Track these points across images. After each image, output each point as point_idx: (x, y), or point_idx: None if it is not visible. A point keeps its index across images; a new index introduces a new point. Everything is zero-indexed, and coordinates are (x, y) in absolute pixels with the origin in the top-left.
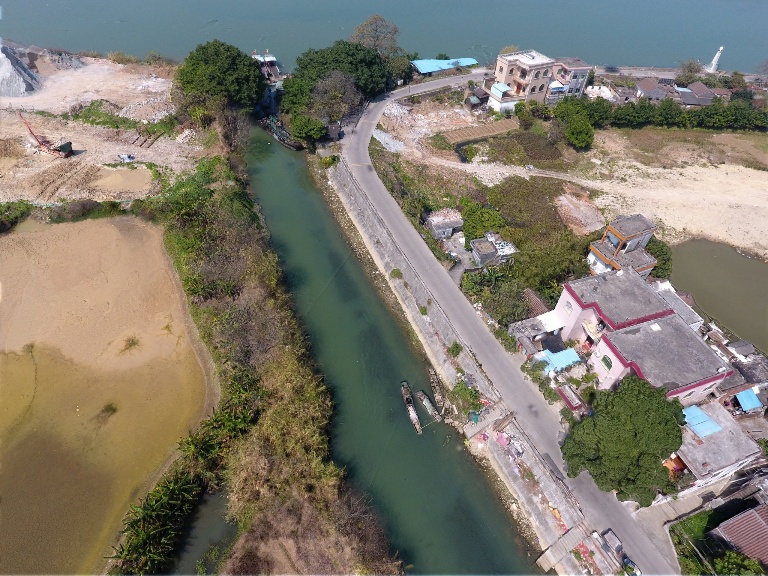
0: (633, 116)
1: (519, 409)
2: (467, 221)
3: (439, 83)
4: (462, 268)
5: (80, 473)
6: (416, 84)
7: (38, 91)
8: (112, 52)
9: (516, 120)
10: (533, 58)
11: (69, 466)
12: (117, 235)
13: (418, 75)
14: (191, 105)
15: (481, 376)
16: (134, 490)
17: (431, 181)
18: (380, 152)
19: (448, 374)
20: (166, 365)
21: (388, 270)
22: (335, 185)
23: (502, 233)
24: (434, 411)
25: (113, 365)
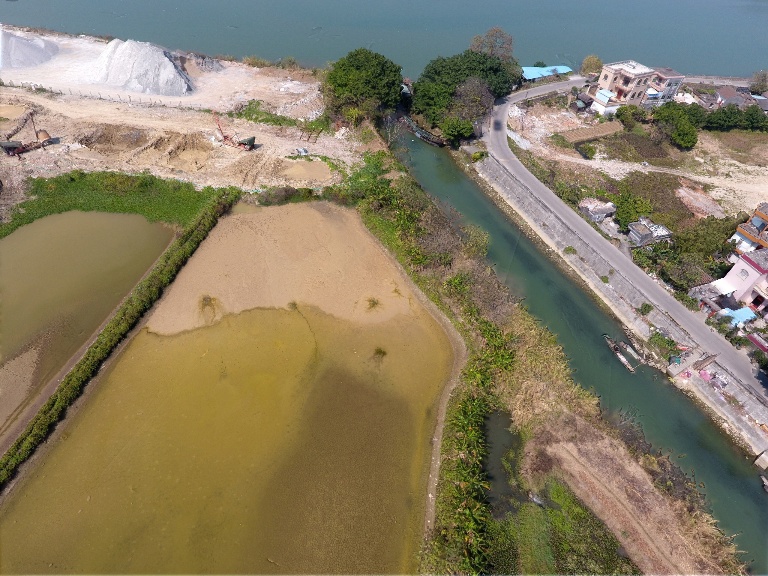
0: (724, 120)
1: (715, 353)
2: (621, 208)
3: (546, 89)
4: (625, 246)
5: (380, 398)
6: (526, 89)
7: (195, 91)
8: (247, 56)
9: (619, 123)
10: (634, 68)
11: (369, 393)
12: (320, 217)
13: (524, 81)
14: (344, 106)
15: (676, 328)
16: (427, 410)
17: (565, 175)
18: (517, 149)
19: (641, 329)
20: (409, 320)
21: (560, 248)
22: (486, 177)
23: (654, 218)
24: (638, 356)
25: (367, 319)
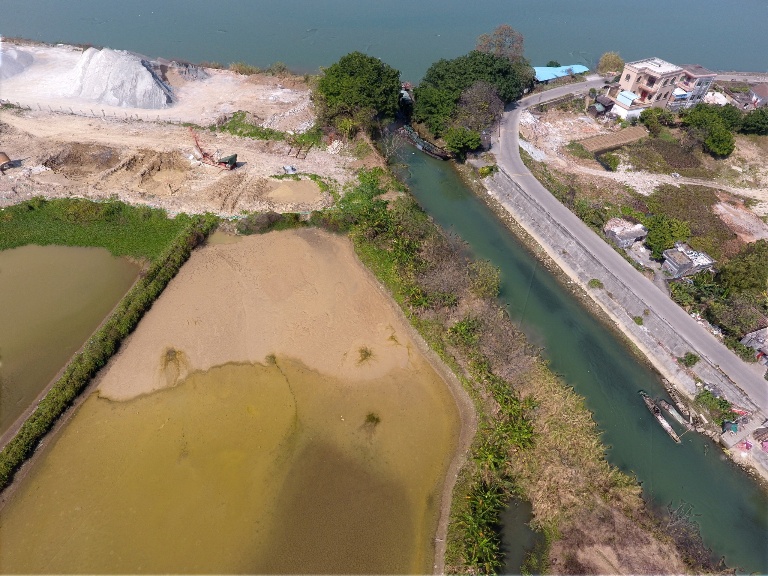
0: (762, 123)
1: None
2: (653, 231)
3: (560, 91)
4: (660, 278)
5: (371, 481)
6: (539, 92)
7: (176, 103)
8: (234, 63)
9: (643, 127)
10: (659, 66)
11: (358, 474)
12: (307, 246)
13: (537, 83)
14: (337, 116)
15: (729, 386)
16: (428, 498)
17: (585, 190)
18: (530, 161)
19: (685, 384)
20: (407, 375)
21: (584, 280)
22: (496, 195)
23: (692, 243)
24: (684, 420)
25: (358, 375)
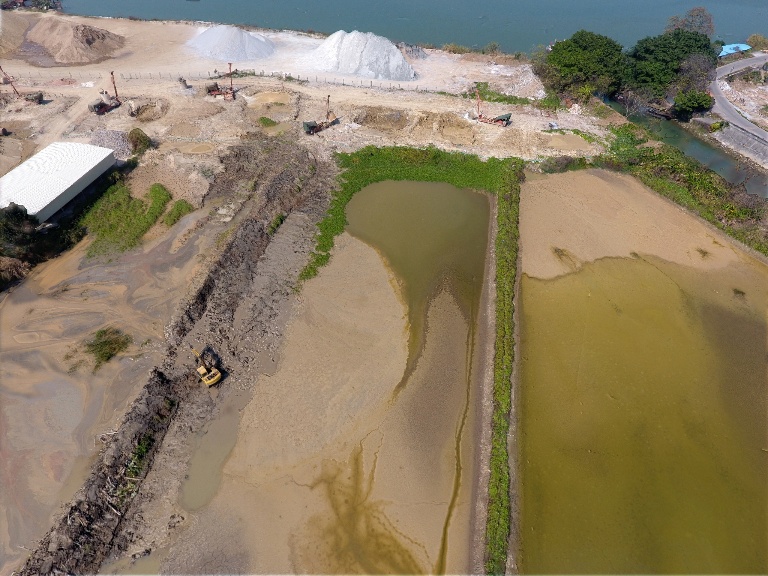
0: None
1: None
2: None
3: (739, 65)
4: None
5: (765, 328)
6: (721, 66)
7: (419, 76)
8: (447, 44)
9: None
10: None
11: (753, 324)
12: (604, 182)
13: None
14: (572, 84)
15: None
16: None
17: None
18: None
19: None
20: (744, 266)
21: None
22: (730, 145)
23: None
24: None
25: (707, 265)
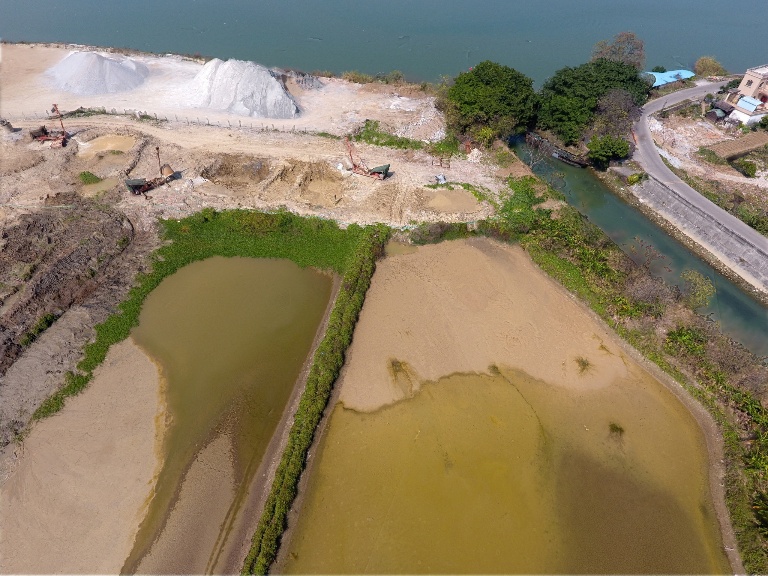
0: None
1: None
2: None
3: (677, 97)
4: None
5: (640, 491)
6: (656, 98)
7: (303, 112)
8: (347, 72)
9: (766, 133)
10: None
11: (624, 484)
12: (484, 256)
13: None
14: (473, 125)
15: None
16: (701, 507)
17: None
18: None
19: None
20: (632, 385)
21: None
22: (649, 203)
23: None
24: None
25: (584, 385)
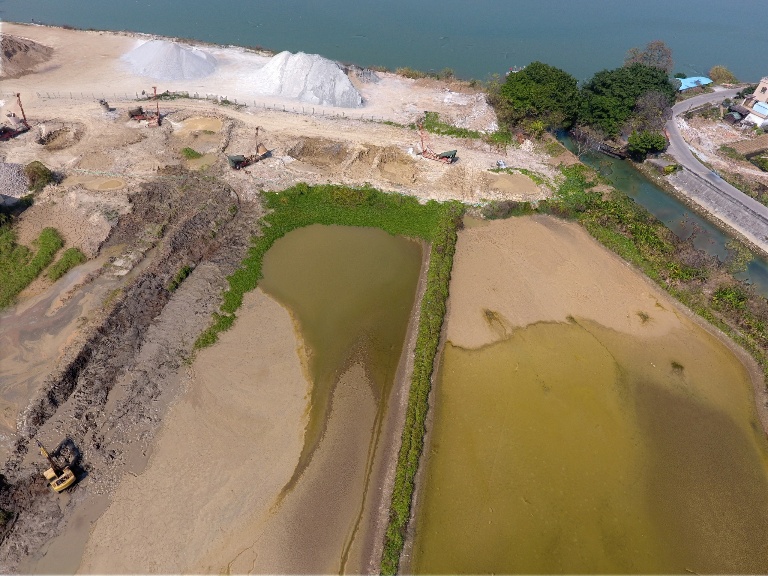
0: None
1: None
2: None
3: (698, 100)
4: None
5: (702, 411)
6: (681, 101)
7: (367, 103)
8: (401, 68)
9: None
10: None
11: (689, 406)
12: (548, 230)
13: None
14: (525, 118)
15: None
16: (751, 423)
17: None
18: None
19: None
20: (686, 334)
21: None
22: (683, 190)
23: None
24: None
25: (647, 333)
